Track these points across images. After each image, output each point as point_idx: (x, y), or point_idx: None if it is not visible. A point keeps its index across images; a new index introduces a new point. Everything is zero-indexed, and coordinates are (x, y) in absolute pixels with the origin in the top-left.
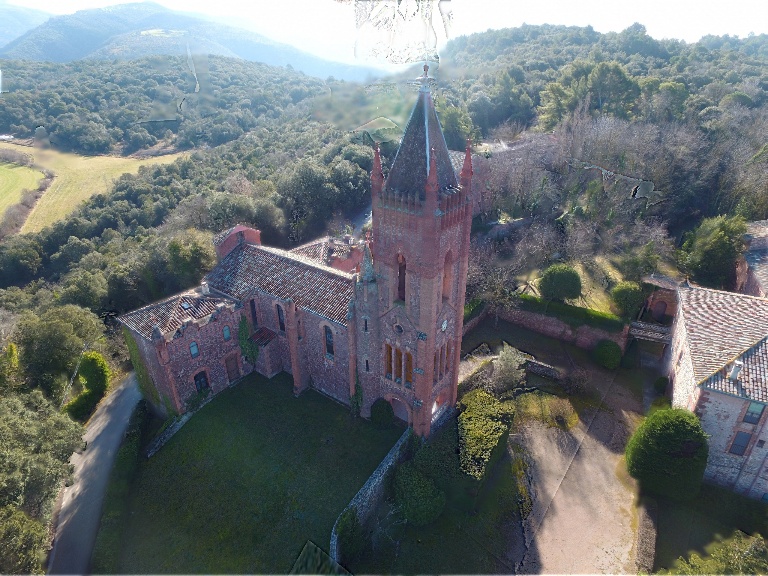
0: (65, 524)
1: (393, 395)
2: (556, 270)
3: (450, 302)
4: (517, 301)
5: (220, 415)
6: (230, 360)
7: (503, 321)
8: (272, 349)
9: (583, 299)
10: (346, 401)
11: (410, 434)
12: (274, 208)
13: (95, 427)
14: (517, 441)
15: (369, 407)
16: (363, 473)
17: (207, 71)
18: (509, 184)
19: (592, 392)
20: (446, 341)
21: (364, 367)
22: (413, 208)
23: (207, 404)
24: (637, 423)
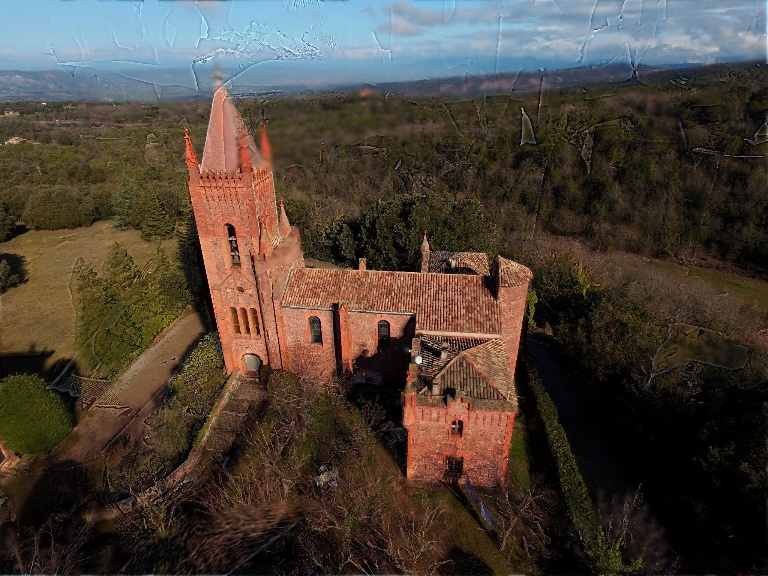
0: None
1: None
2: None
3: None
4: None
5: None
6: None
7: None
8: None
9: None
10: None
11: None
12: (766, 441)
13: None
14: None
15: None
16: None
17: None
18: None
19: None
20: None
21: None
22: None
23: None
24: (7, 508)
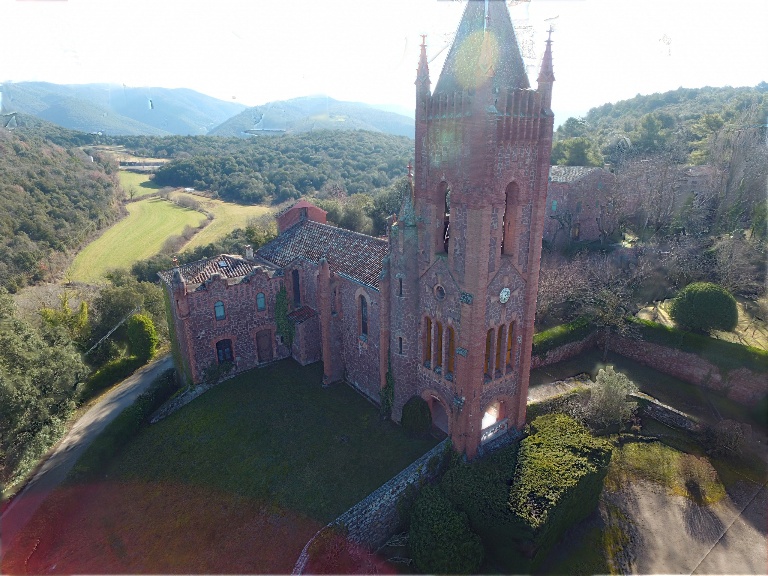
0: (44, 474)
1: (431, 391)
2: (698, 288)
3: (515, 263)
4: (638, 327)
5: (235, 392)
6: (263, 336)
7: (617, 355)
8: (309, 330)
9: (742, 338)
10: (378, 399)
11: (447, 448)
12: (362, 213)
13: (123, 389)
14: (617, 502)
15: (401, 406)
16: (372, 486)
17: (326, 96)
18: (637, 193)
19: (752, 461)
20: (508, 321)
21: (397, 347)
22: (460, 109)
23: (228, 380)
24: None
